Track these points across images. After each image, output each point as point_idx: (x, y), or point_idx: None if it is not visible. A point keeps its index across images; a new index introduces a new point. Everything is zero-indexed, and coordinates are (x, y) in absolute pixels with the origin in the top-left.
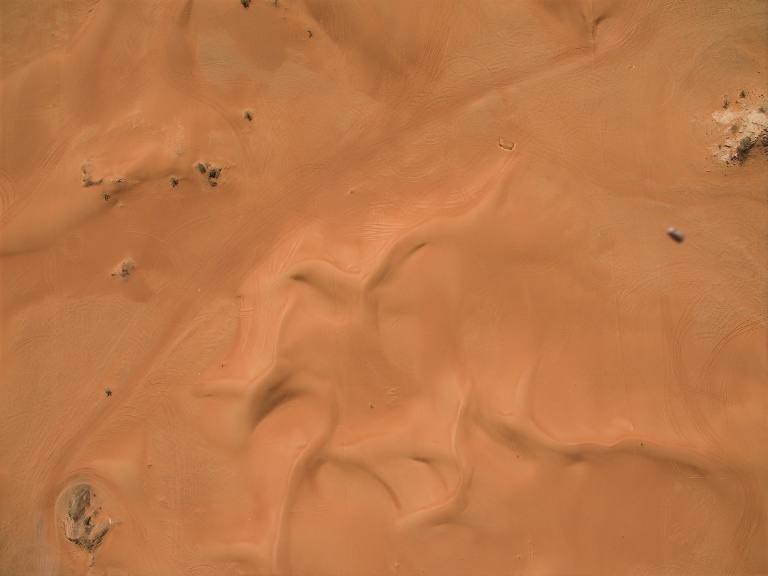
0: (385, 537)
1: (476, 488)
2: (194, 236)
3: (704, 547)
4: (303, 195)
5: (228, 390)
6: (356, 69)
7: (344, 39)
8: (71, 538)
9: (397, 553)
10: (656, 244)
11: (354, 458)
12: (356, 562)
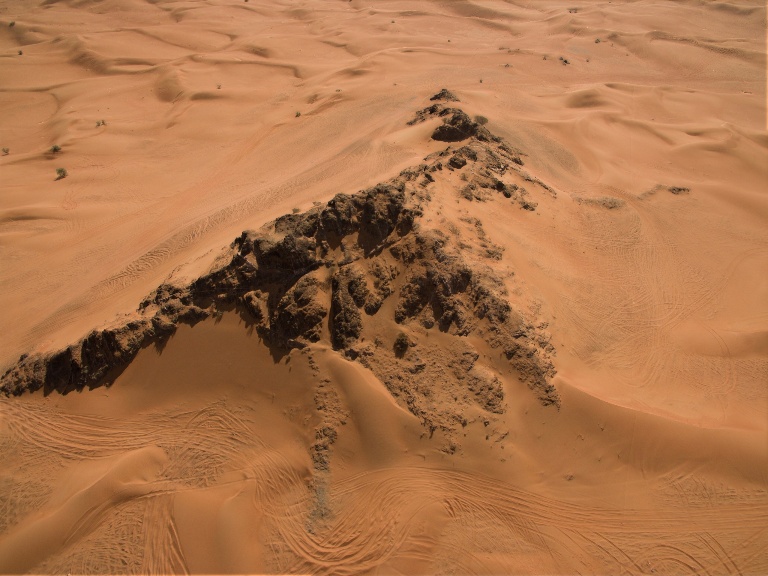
0: (660, 153)
1: (743, 143)
2: None
3: None
4: None
5: None
6: None
7: (647, 57)
8: None
9: (670, 159)
10: None
11: (640, 123)
12: (636, 150)
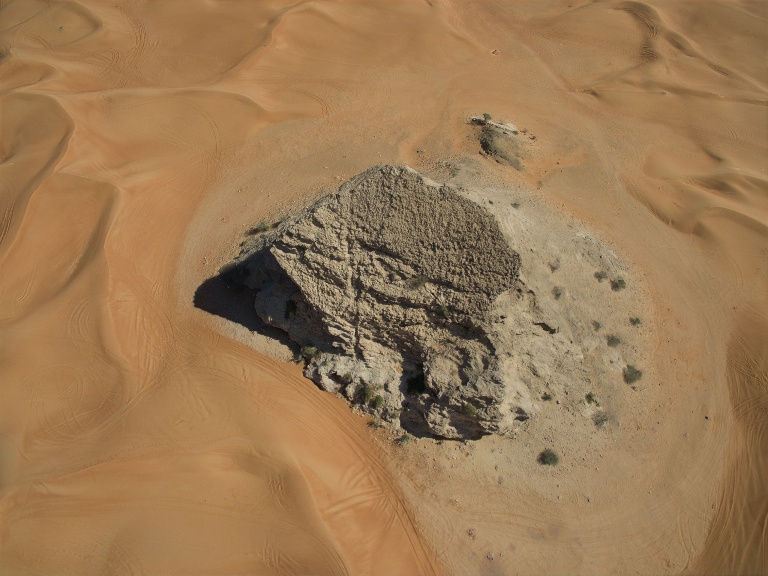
0: None
1: None
2: None
3: (168, 71)
4: None
5: None
6: None
7: None
8: None
9: None
10: (409, 87)
11: None
12: None
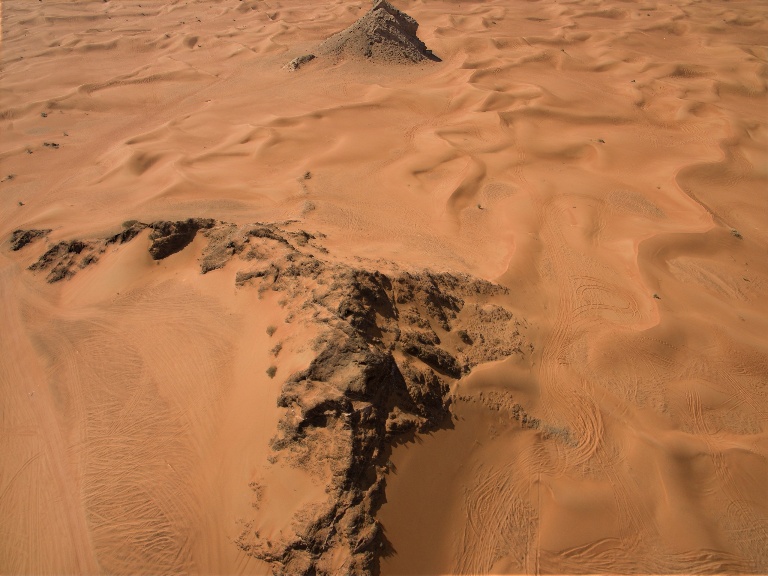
0: None
1: None
2: (54, 160)
3: None
4: (115, 137)
5: (111, 172)
6: (118, 113)
7: (106, 109)
8: (22, 237)
9: None
10: None
11: (208, 154)
12: None
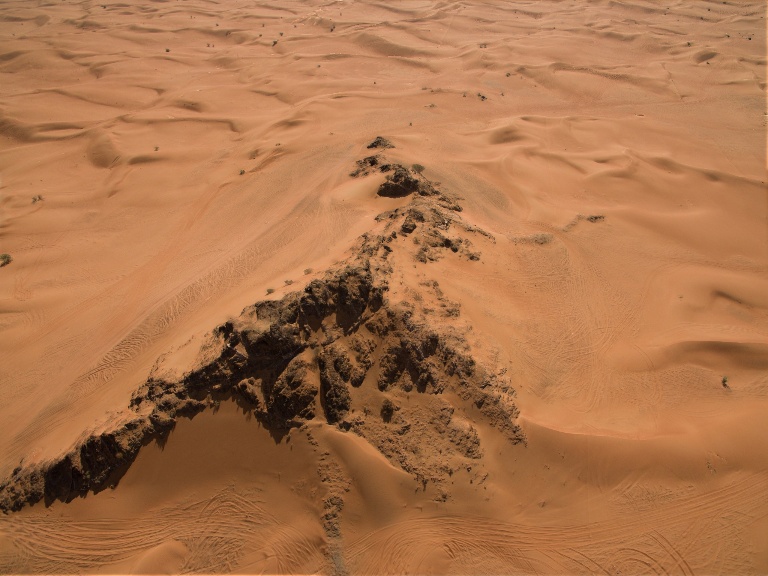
0: None
1: (642, 168)
2: None
3: None
4: None
5: None
6: (557, 94)
7: (552, 87)
8: (376, 141)
9: None
10: None
11: (555, 155)
12: (555, 182)
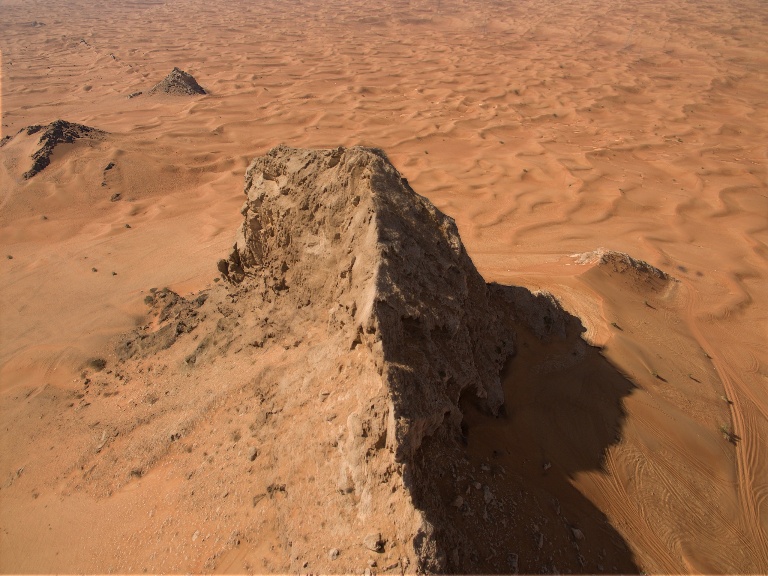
0: None
1: None
2: (6, 129)
3: None
4: None
5: None
6: None
7: (33, 115)
8: None
9: None
10: None
11: None
12: None
